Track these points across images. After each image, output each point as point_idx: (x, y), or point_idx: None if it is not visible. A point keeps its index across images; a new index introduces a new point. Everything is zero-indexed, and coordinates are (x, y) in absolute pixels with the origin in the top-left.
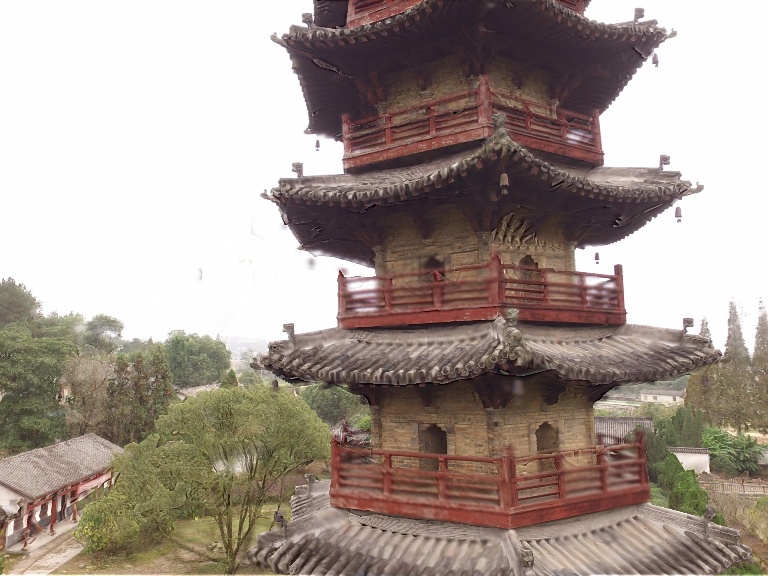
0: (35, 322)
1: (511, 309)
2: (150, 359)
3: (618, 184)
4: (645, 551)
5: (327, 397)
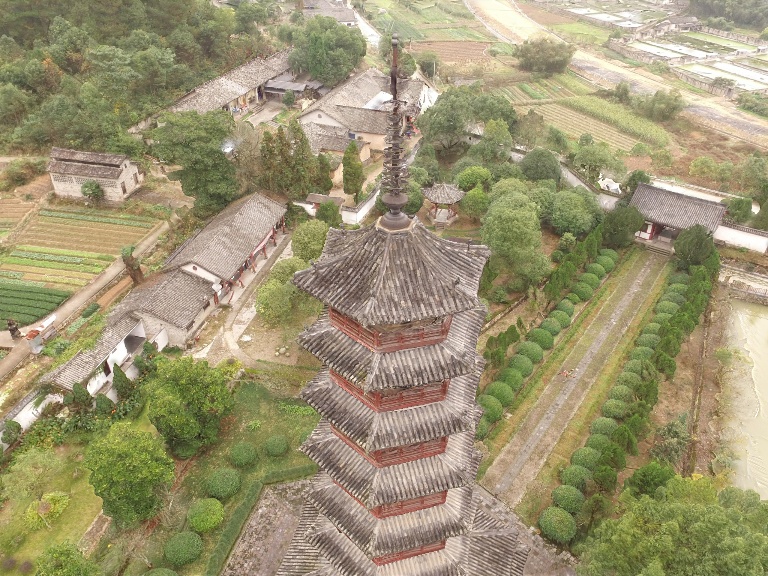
0: (193, 17)
1: (371, 540)
2: (289, 127)
3: (445, 469)
4: (431, 569)
5: (443, 125)
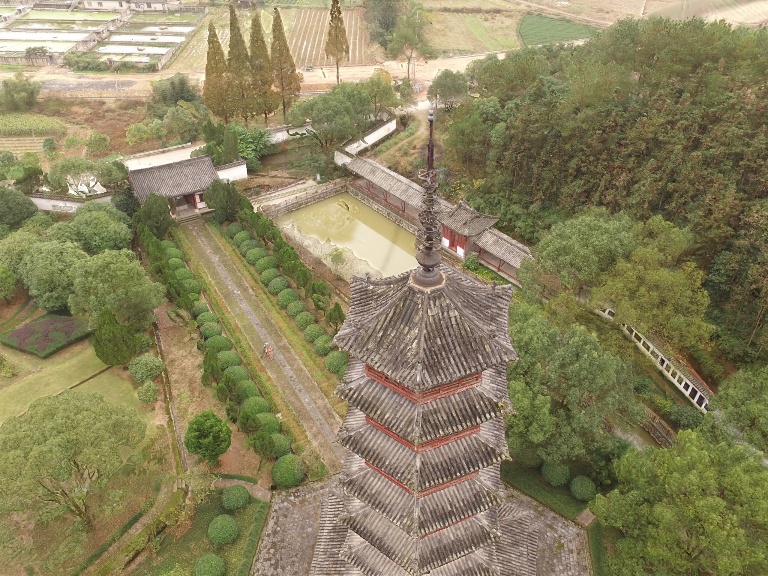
0: None
1: None
2: None
3: None
4: None
5: None
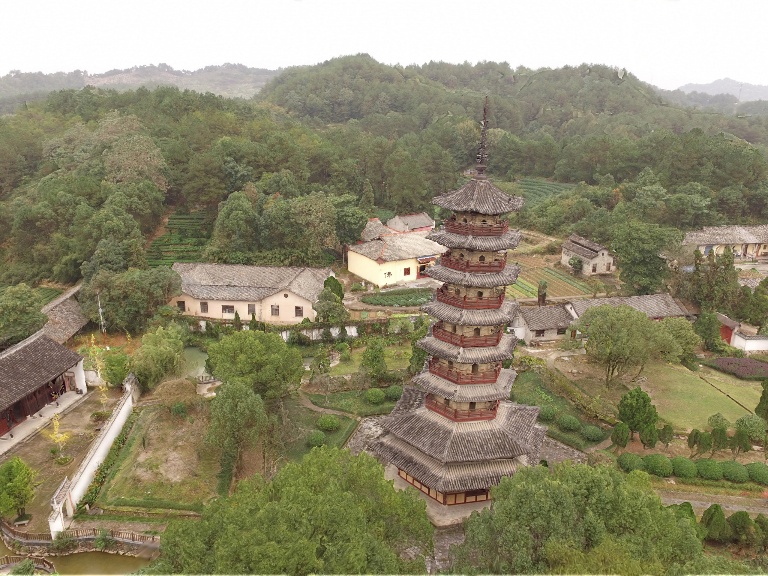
0: (757, 183)
1: None
2: None
3: None
4: None
5: None
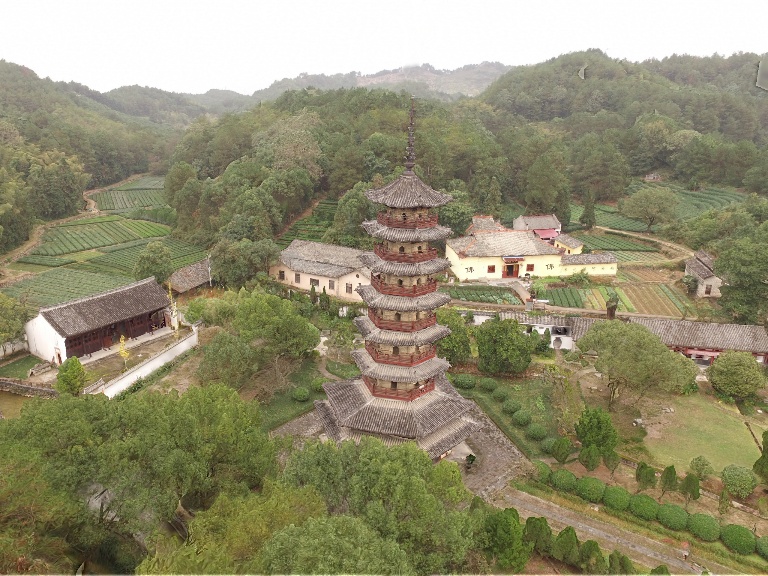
0: None
1: None
2: None
3: None
4: None
5: None
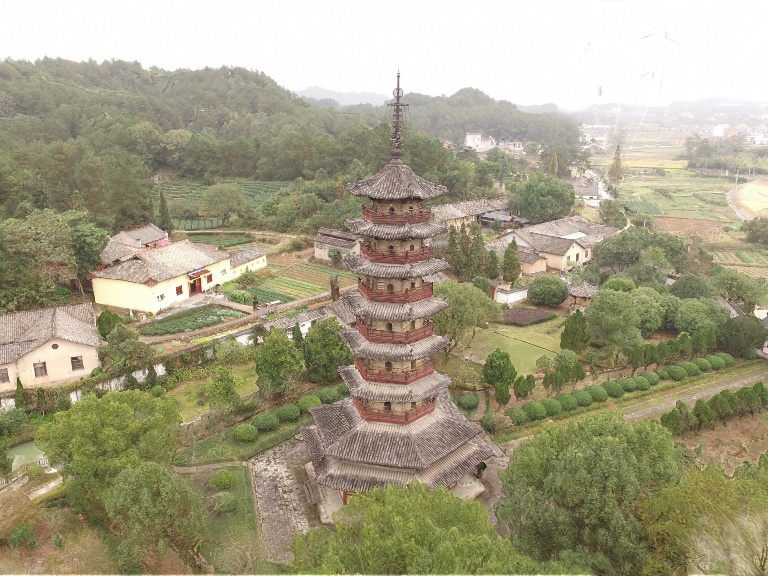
0: (444, 167)
1: (357, 344)
2: (471, 226)
3: None
4: (396, 393)
5: (612, 251)
